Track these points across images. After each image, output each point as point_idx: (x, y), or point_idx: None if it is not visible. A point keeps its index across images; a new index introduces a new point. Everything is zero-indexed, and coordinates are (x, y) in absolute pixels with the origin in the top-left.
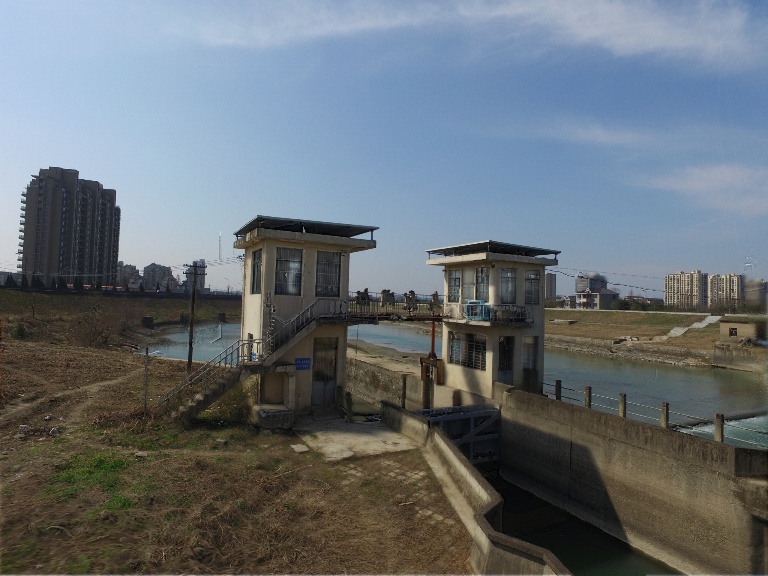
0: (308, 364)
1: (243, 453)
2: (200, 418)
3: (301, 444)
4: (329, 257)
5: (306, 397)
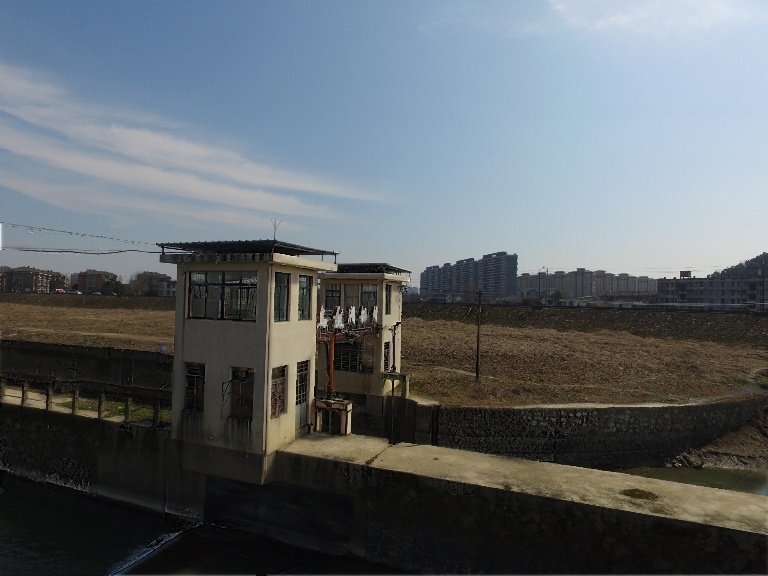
0: None
1: None
2: None
3: None
4: None
5: None
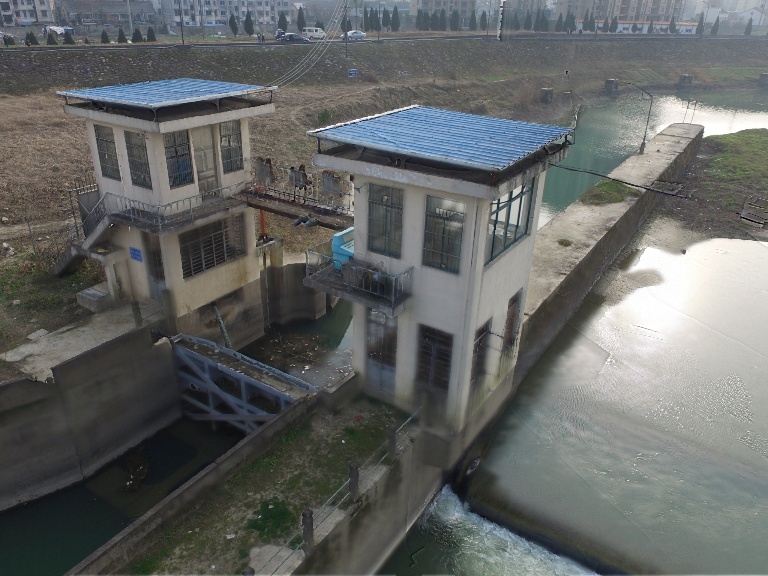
0: (140, 256)
1: (9, 319)
2: (79, 274)
3: (48, 331)
4: (136, 139)
5: (145, 288)
